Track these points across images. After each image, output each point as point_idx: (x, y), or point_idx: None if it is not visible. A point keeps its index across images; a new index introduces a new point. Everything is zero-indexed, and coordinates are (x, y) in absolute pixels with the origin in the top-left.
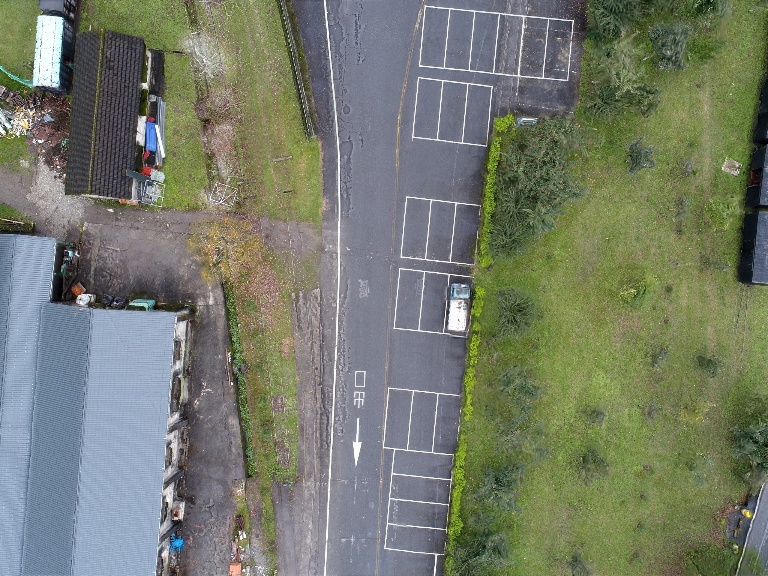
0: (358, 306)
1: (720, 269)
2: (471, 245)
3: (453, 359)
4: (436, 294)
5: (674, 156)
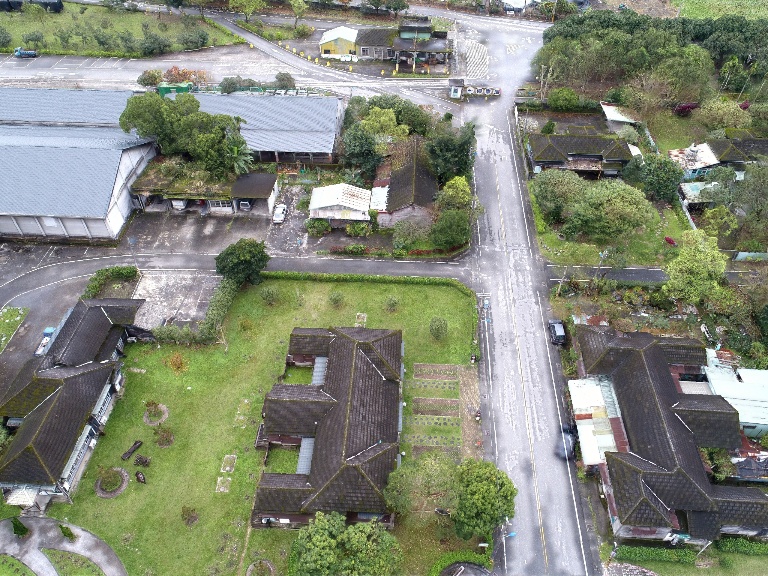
0: (8, 74)
1: (48, 8)
2: (3, 54)
3: (49, 57)
4: (18, 60)
5: (3, 22)
